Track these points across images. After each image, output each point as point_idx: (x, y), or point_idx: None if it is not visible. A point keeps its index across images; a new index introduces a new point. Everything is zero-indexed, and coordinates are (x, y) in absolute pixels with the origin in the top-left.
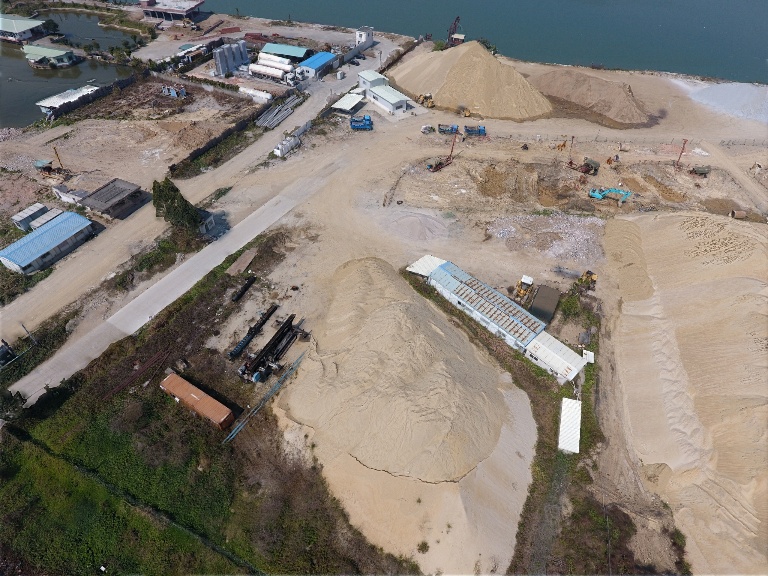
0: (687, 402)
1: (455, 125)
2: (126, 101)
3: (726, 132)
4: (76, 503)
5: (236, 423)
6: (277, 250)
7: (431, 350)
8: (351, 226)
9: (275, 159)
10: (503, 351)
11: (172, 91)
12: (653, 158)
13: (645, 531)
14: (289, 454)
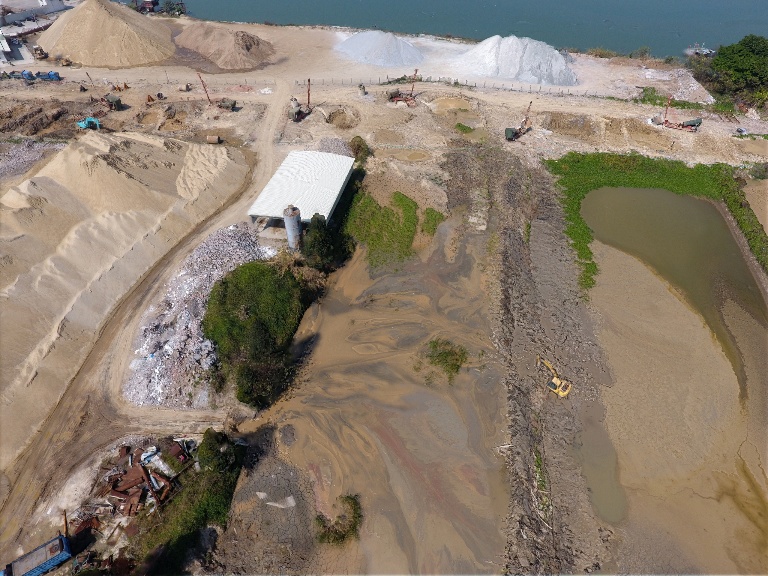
0: None
1: (27, 71)
2: None
3: (322, 75)
4: None
5: None
6: None
7: None
8: None
9: None
10: None
11: None
12: (206, 96)
13: None
14: None
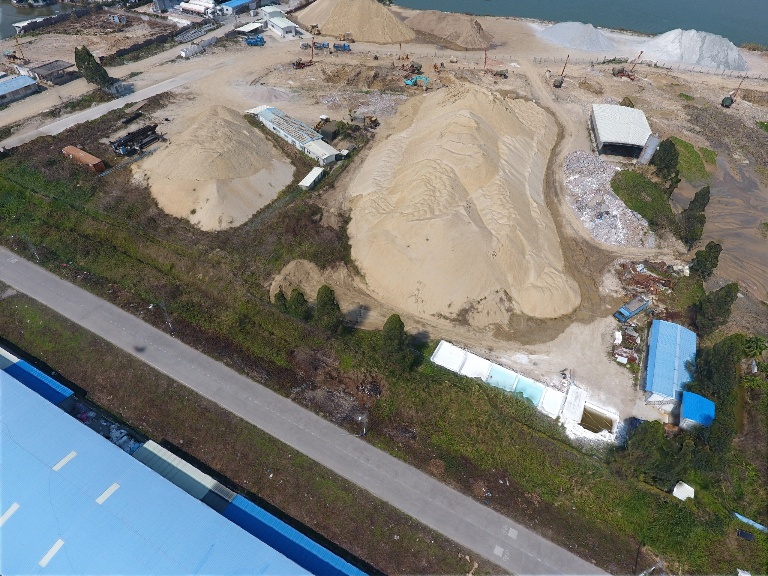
0: (391, 169)
1: None
2: (80, 24)
3: (546, 55)
4: (3, 193)
5: (106, 171)
6: (162, 102)
7: (230, 134)
8: (221, 94)
9: (181, 59)
10: (291, 150)
11: (116, 18)
12: (473, 67)
13: (328, 214)
14: (134, 183)
